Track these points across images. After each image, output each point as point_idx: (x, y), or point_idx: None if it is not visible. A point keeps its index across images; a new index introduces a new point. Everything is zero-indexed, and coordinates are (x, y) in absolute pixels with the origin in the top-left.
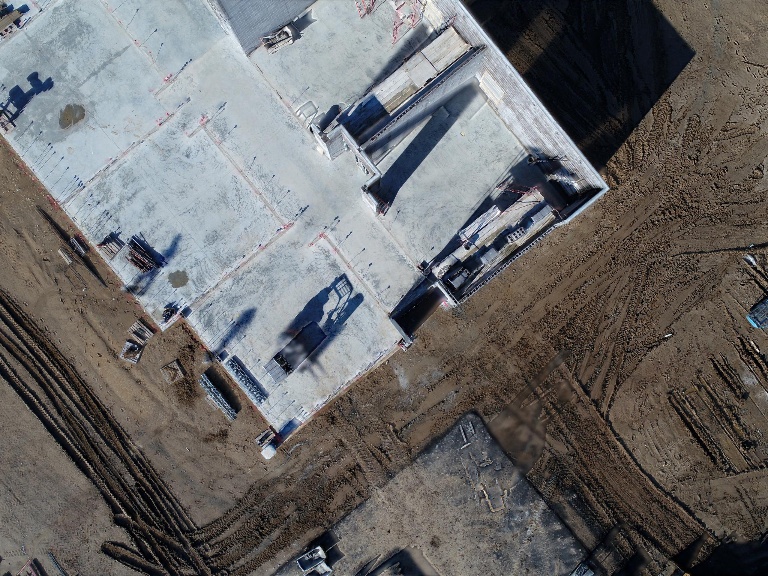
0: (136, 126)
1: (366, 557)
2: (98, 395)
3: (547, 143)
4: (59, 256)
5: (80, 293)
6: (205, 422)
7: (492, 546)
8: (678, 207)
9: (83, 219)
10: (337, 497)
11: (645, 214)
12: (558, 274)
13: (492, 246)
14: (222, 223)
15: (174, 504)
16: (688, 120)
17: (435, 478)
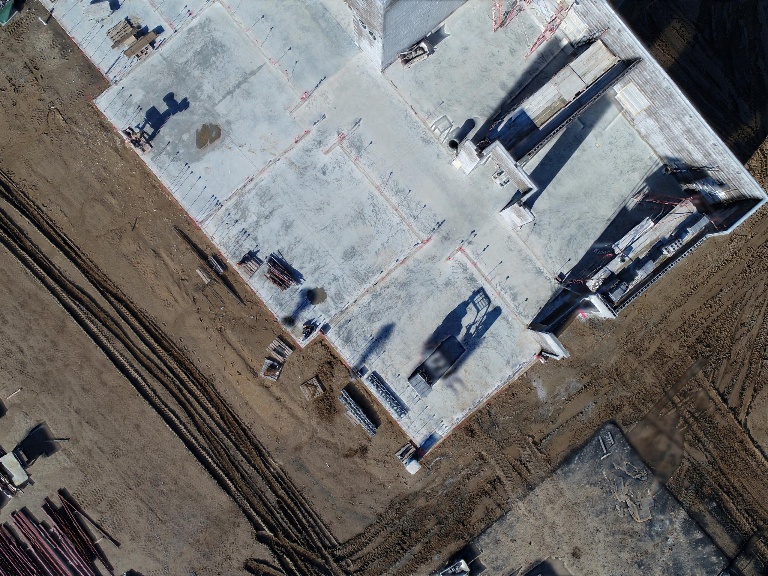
0: (272, 144)
1: (508, 569)
2: (238, 413)
3: (695, 154)
4: (197, 275)
5: (218, 312)
6: (345, 438)
7: (633, 556)
8: None
9: (221, 238)
10: (478, 510)
11: None
12: (694, 283)
13: (646, 258)
14: (359, 239)
15: (315, 520)
16: None
17: (575, 489)
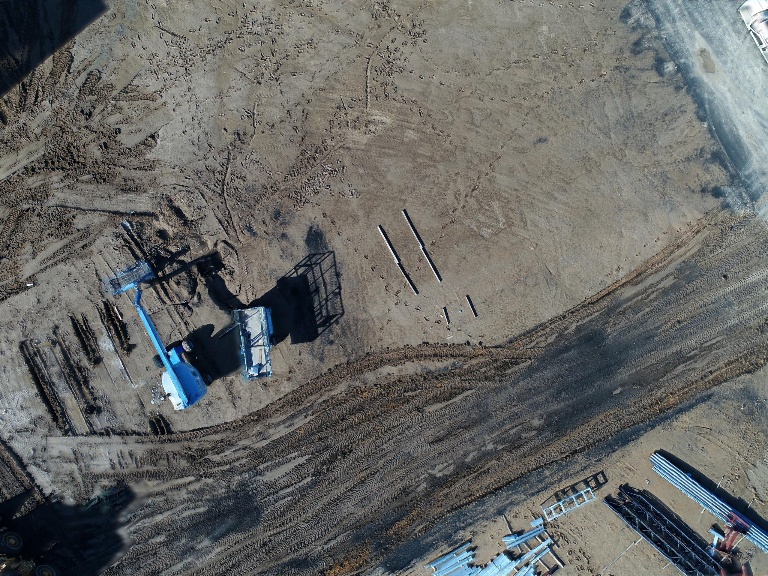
0: None
1: None
2: None
3: None
4: None
5: None
6: None
7: None
8: (63, 159)
9: None
10: None
11: (27, 159)
12: None
13: None
14: None
15: None
16: (88, 74)
17: None
